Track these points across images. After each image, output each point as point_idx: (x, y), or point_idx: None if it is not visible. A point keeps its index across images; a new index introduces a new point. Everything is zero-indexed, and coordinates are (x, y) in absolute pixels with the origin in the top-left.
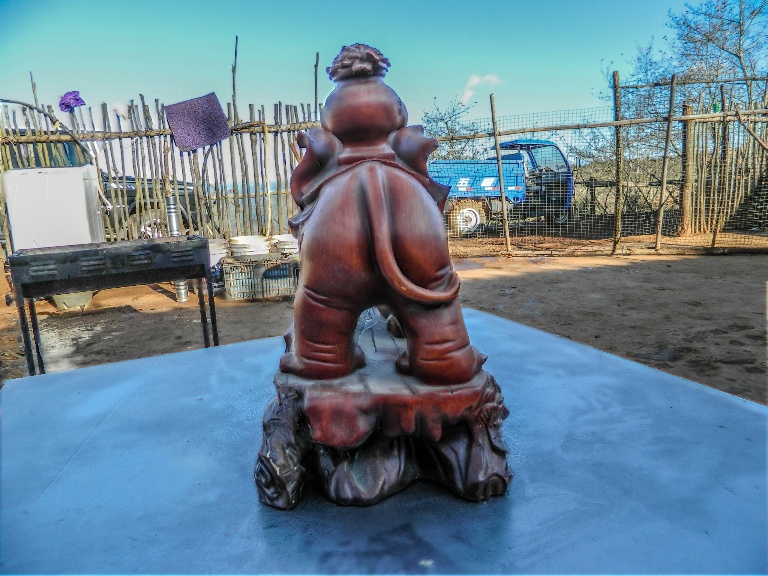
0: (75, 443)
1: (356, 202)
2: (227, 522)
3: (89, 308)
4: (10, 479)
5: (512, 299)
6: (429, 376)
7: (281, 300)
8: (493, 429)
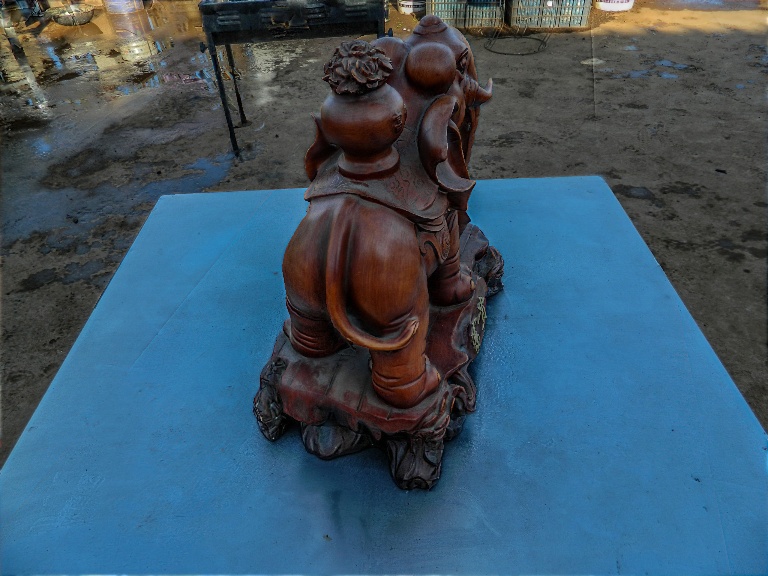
0: (174, 304)
1: (318, 250)
2: (228, 437)
3: (293, 26)
4: (126, 333)
5: (762, 75)
6: (378, 394)
7: (482, 34)
8: (428, 444)
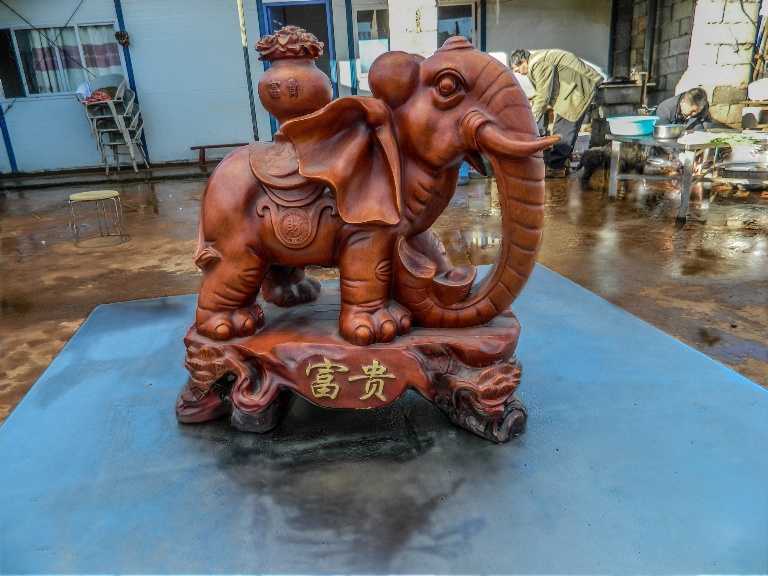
0: None
1: None
2: None
3: None
4: None
5: None
6: None
7: None
8: None
